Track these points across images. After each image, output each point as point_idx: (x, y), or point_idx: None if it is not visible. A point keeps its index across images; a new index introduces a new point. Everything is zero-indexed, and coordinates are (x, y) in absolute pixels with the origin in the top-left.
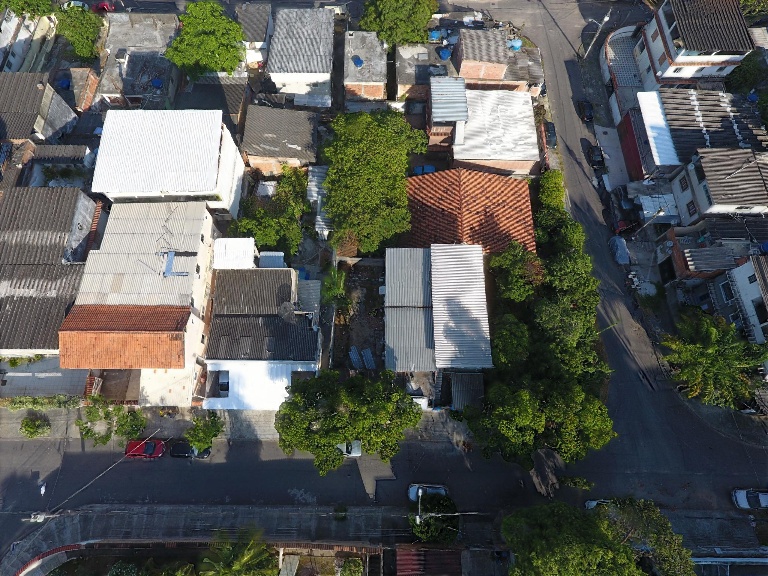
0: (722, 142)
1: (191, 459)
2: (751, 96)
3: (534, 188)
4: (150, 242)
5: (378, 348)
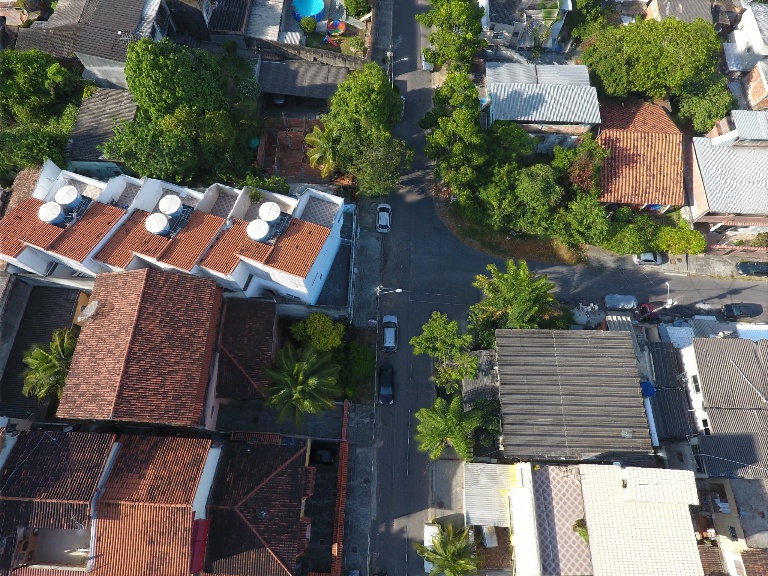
0: None
1: None
2: None
3: None
4: None
5: None
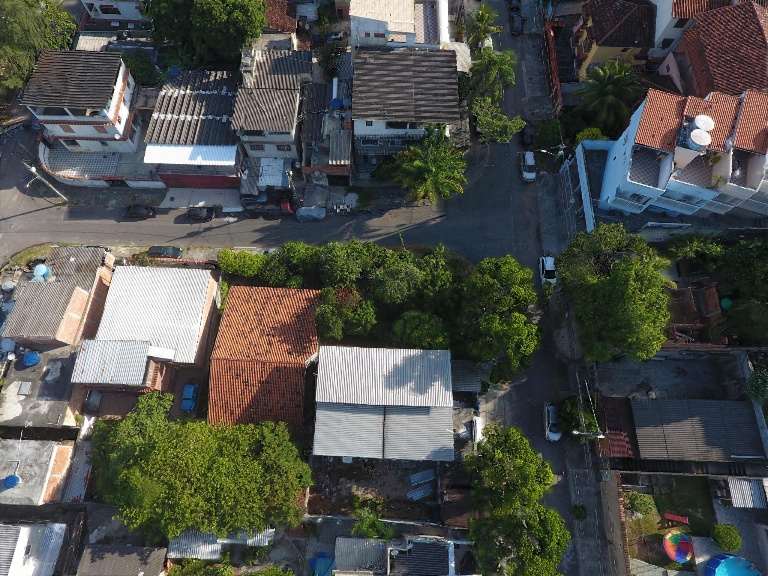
0: (218, 107)
1: None
2: (173, 72)
3: (230, 279)
4: None
5: (409, 466)
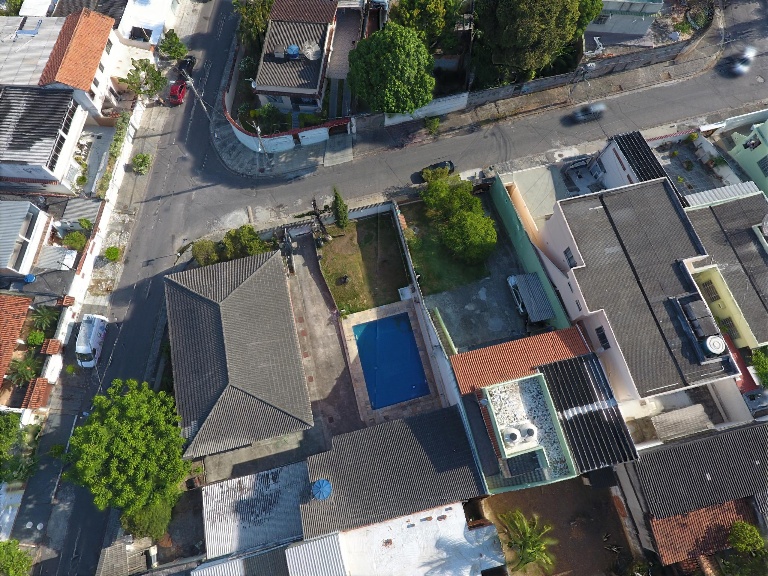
0: None
1: None
2: None
3: None
4: (2, 46)
5: None
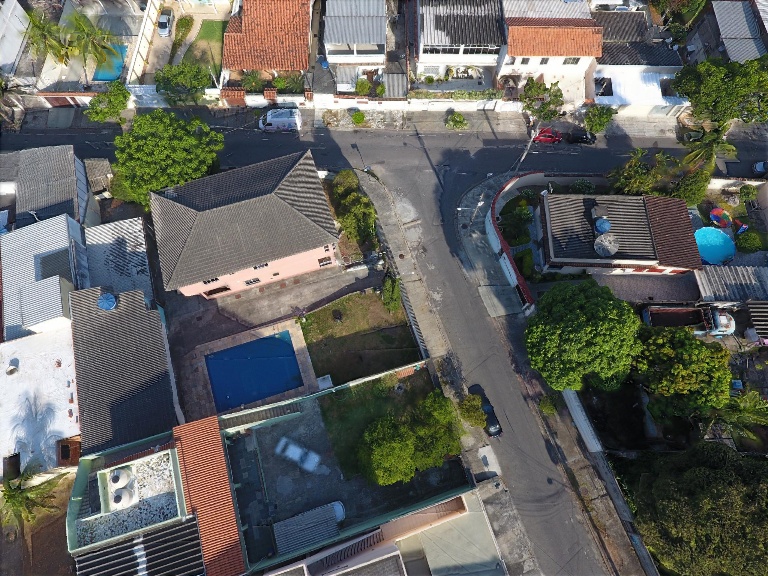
0: None
1: (582, 145)
2: None
3: None
4: None
5: None
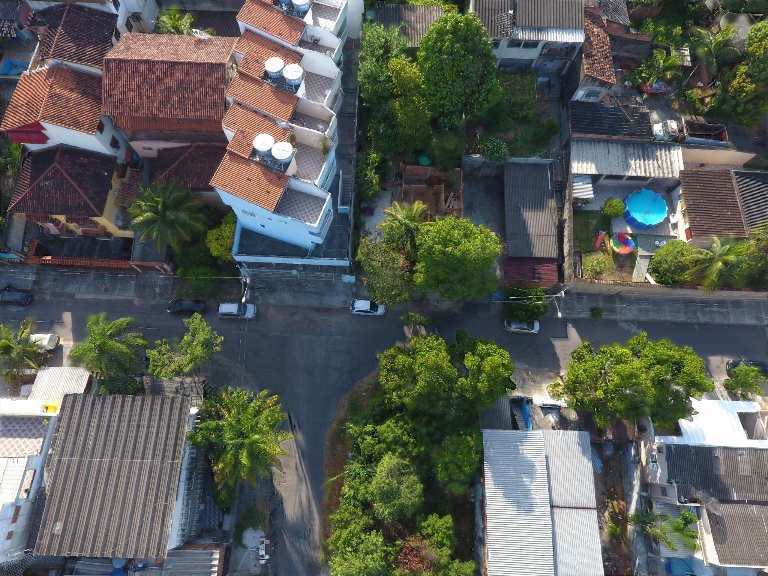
0: None
1: None
2: None
3: None
4: None
5: None
